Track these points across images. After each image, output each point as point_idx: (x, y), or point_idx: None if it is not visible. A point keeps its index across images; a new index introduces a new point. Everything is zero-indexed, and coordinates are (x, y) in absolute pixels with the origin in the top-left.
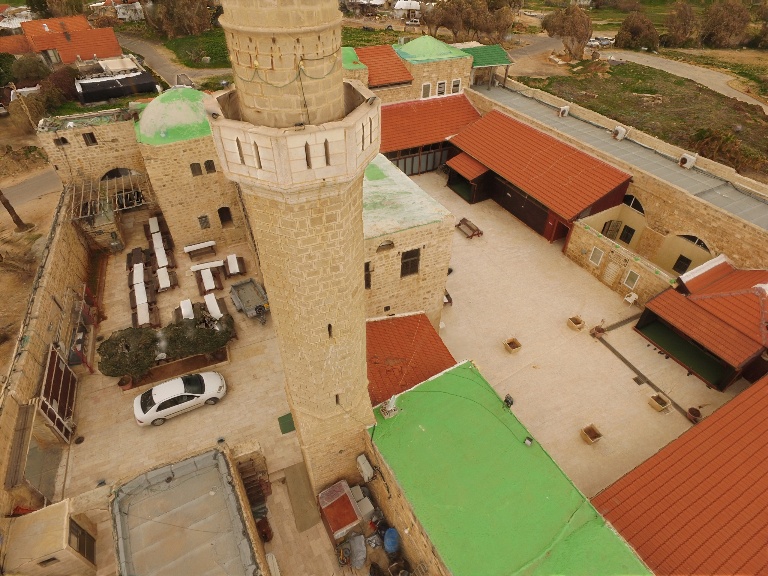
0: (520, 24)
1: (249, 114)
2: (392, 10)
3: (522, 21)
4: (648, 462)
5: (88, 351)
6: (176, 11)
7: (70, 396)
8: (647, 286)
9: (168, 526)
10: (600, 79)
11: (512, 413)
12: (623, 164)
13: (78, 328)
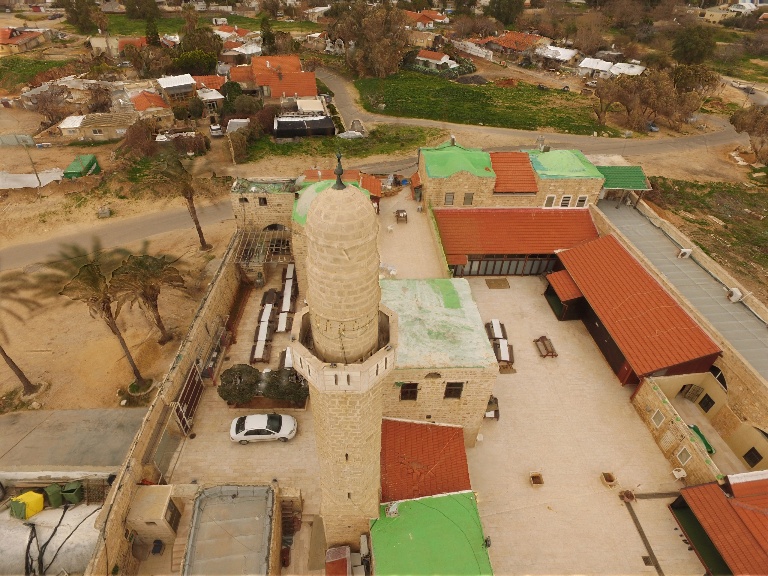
0: (718, 99)
1: None
2: (576, 67)
3: (723, 95)
4: None
5: (217, 367)
6: (371, 56)
7: (196, 400)
8: (696, 469)
9: (223, 531)
10: None
11: (487, 553)
12: (716, 336)
13: None
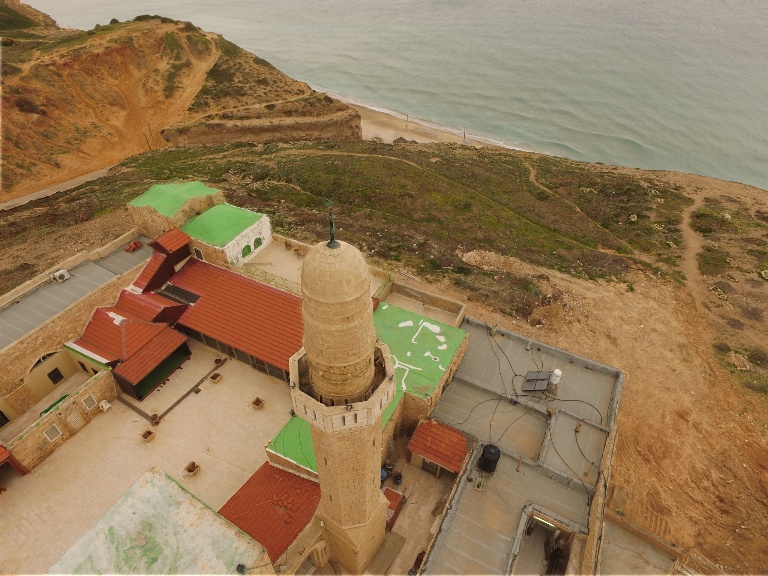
0: None
1: None
2: None
3: None
4: (279, 366)
5: None
6: None
7: None
8: (101, 390)
9: None
10: None
11: None
12: None
13: None
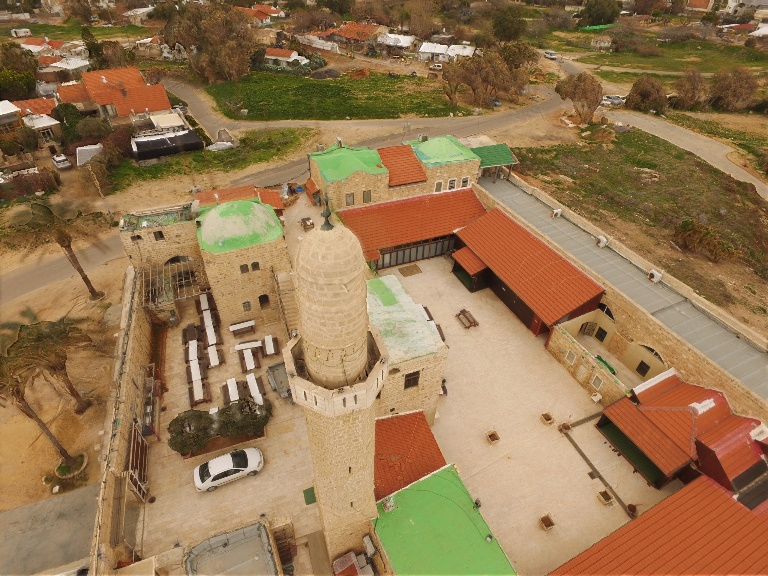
0: (539, 71)
1: (311, 370)
2: (417, 53)
3: (541, 66)
4: (582, 555)
5: (156, 421)
6: (218, 60)
7: (144, 462)
8: (609, 390)
9: None
10: (604, 150)
11: (480, 513)
12: (598, 278)
13: (148, 401)
